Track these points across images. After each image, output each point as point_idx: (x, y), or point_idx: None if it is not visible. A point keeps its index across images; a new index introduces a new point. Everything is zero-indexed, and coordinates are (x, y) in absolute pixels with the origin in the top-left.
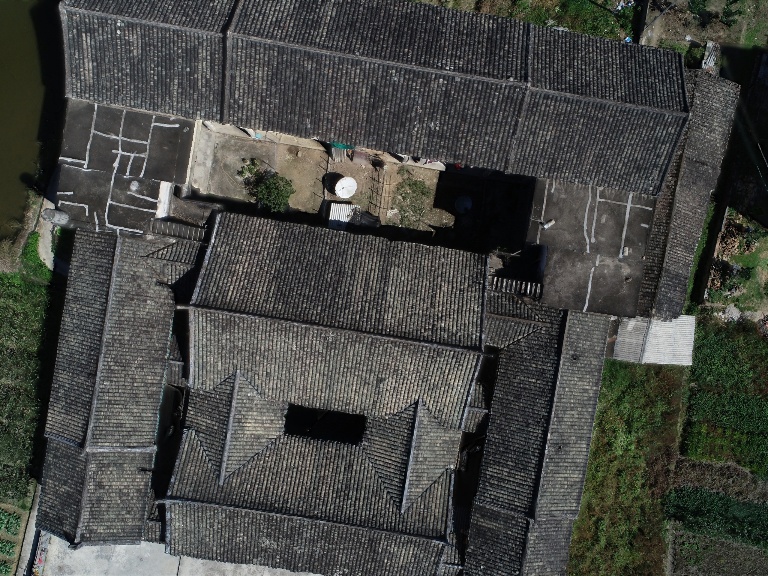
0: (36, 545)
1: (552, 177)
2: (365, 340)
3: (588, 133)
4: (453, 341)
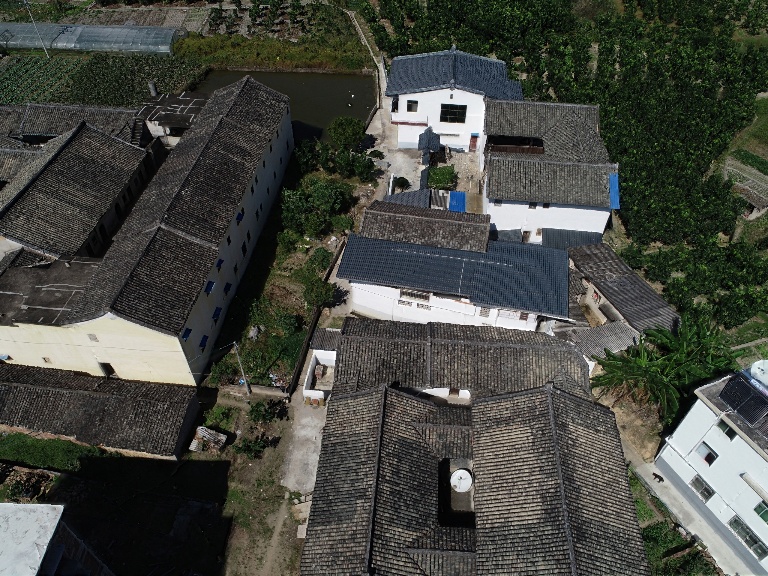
0: None
1: None
2: None
3: None
4: (6, 218)
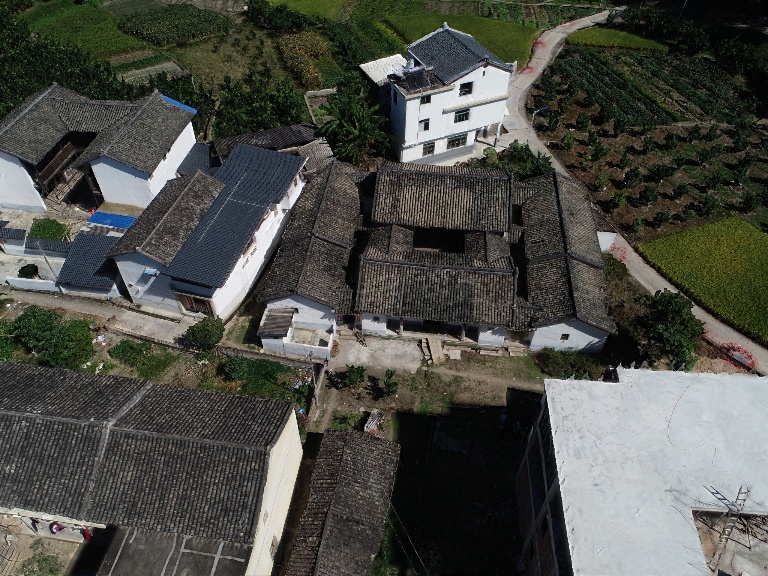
0: None
1: (132, 524)
2: None
3: (170, 472)
4: None
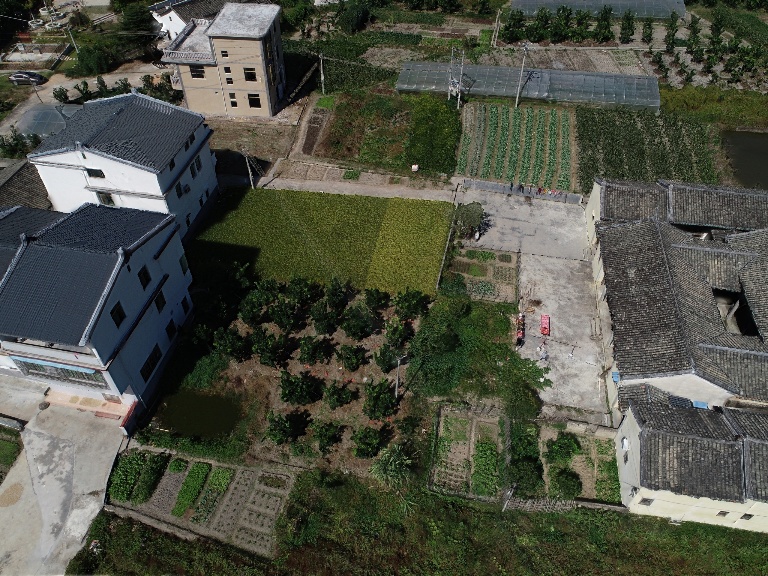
0: None
1: None
2: None
3: None
4: None
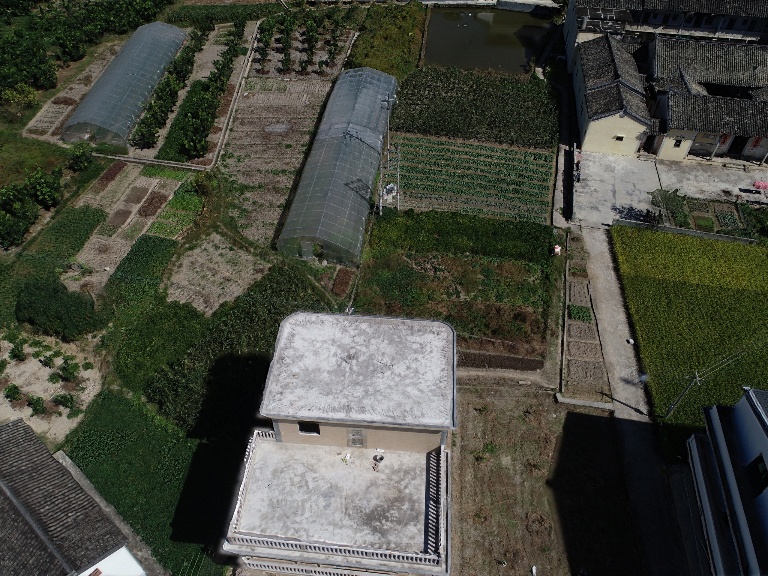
0: (566, 165)
1: None
2: (743, 49)
3: None
4: None
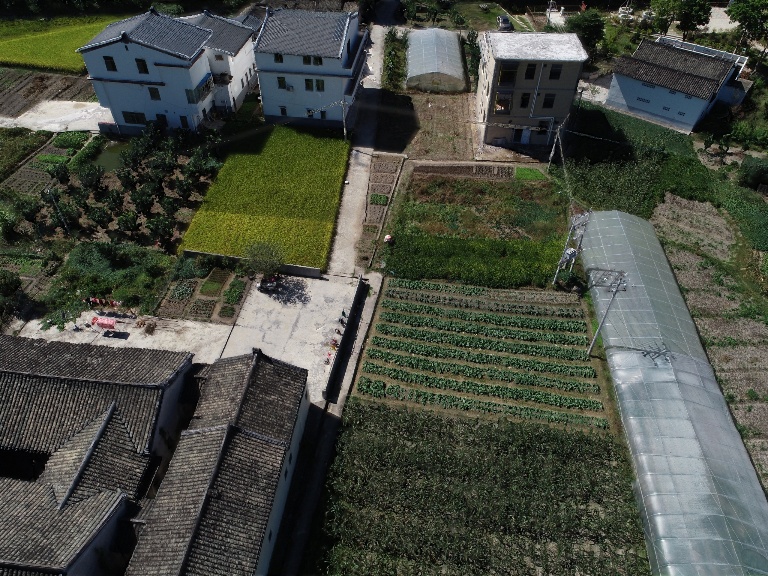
0: (343, 370)
1: None
2: None
3: None
4: None
